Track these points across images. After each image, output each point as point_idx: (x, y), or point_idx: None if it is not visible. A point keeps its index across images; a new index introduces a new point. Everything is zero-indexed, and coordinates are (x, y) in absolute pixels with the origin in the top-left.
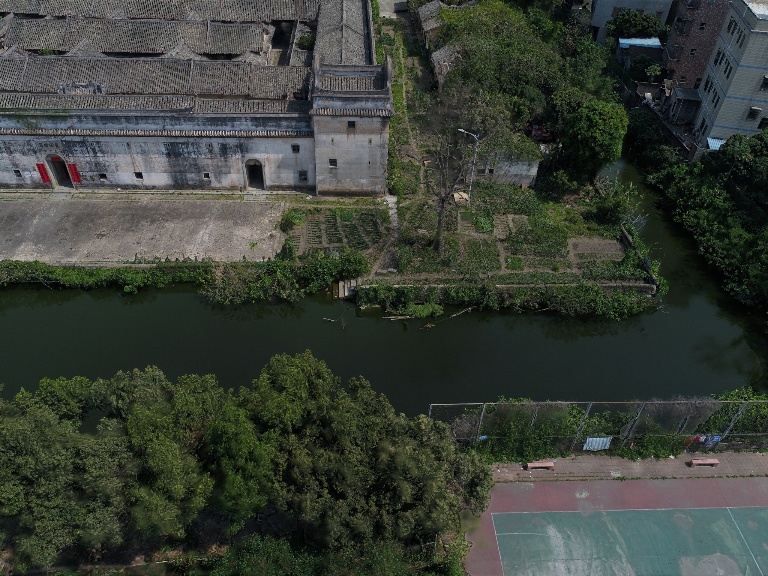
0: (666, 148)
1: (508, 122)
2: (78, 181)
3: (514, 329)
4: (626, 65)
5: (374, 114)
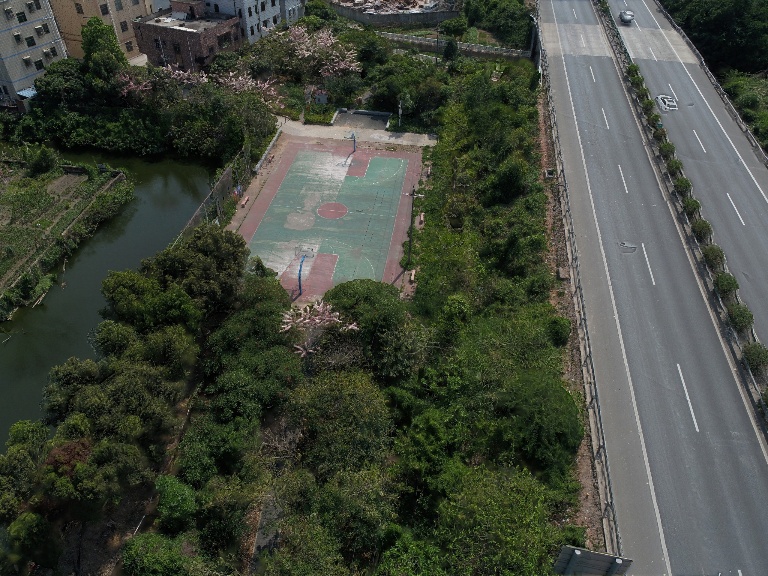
0: (1, 114)
1: None
2: None
3: (96, 251)
4: None
5: None
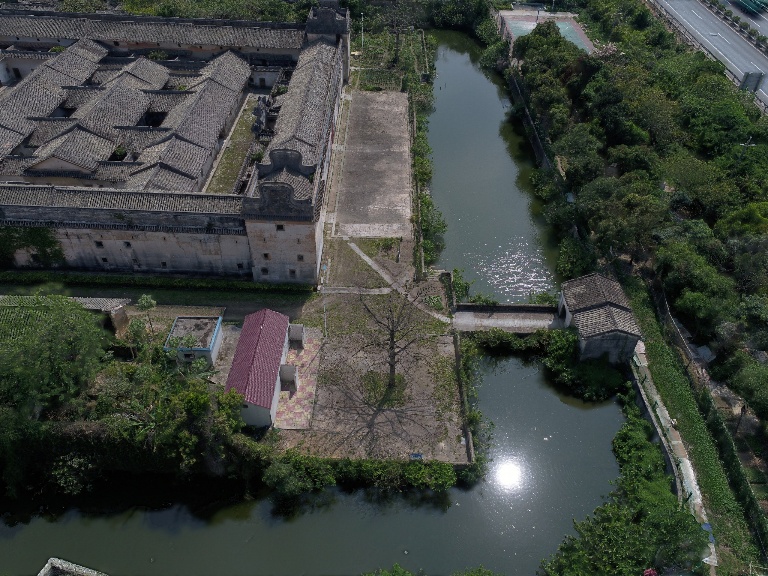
0: None
1: None
2: (333, 136)
3: None
4: None
5: None
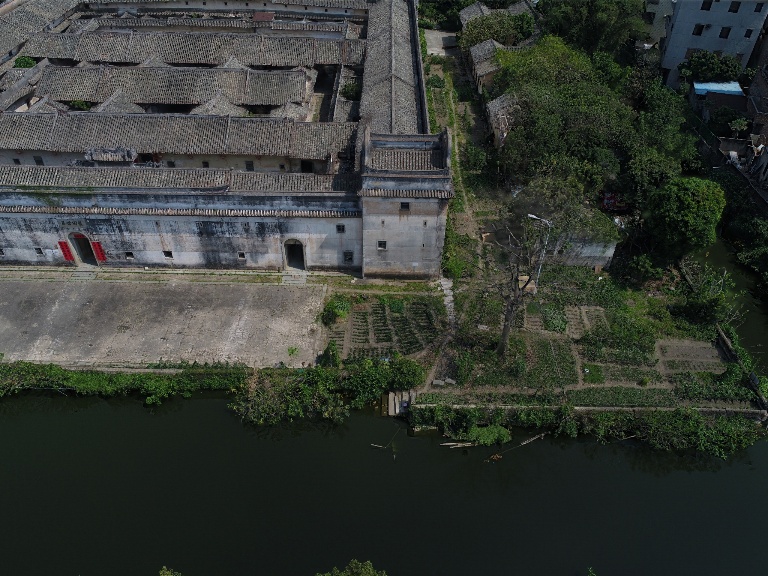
0: (761, 223)
1: (581, 198)
2: (103, 259)
3: (594, 459)
4: (703, 114)
5: (431, 196)
